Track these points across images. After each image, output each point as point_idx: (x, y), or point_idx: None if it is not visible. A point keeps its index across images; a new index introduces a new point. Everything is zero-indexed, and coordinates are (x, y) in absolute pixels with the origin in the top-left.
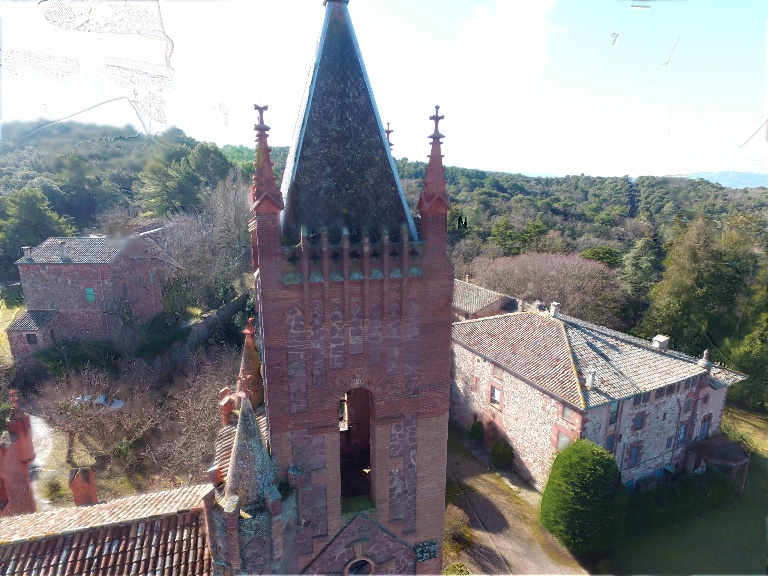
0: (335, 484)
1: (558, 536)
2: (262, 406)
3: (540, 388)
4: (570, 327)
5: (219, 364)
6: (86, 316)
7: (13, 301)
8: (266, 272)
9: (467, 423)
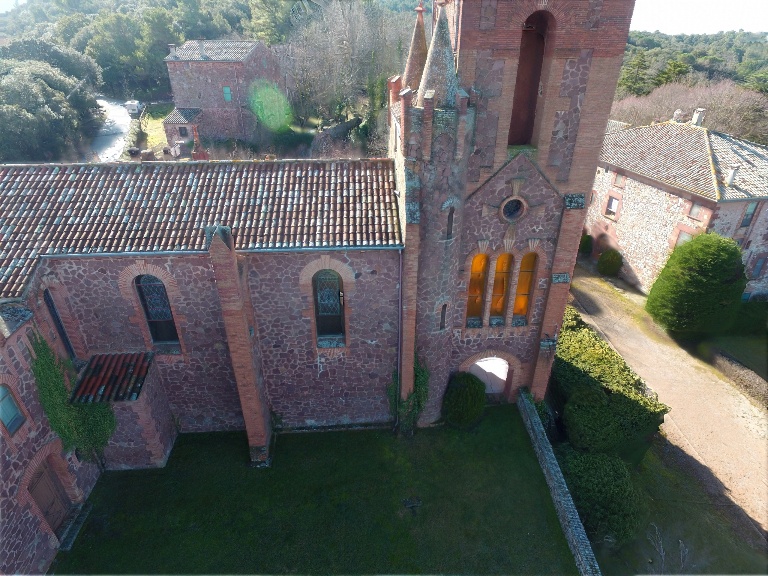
0: (507, 115)
1: (662, 319)
2: None
3: (668, 189)
4: (713, 135)
5: (346, 151)
6: (224, 115)
7: (157, 114)
8: None
9: None
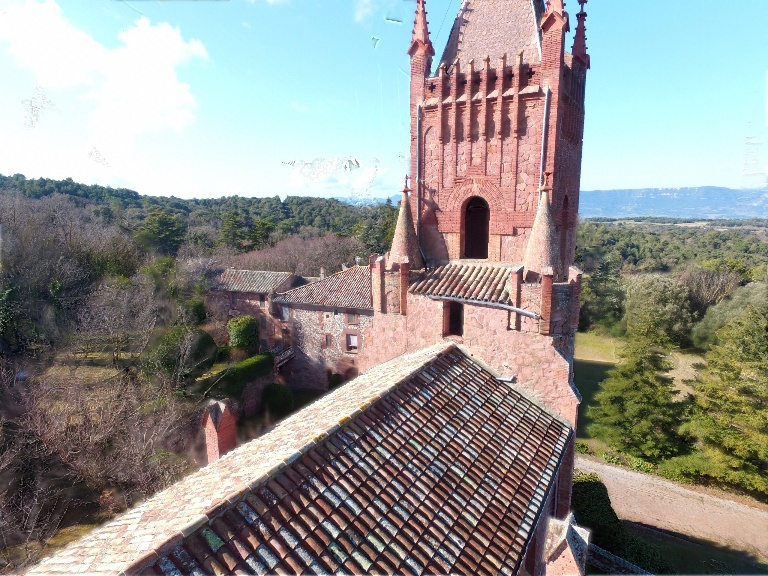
0: None
1: None
2: (428, 263)
3: None
4: None
5: (59, 370)
6: None
7: None
8: (560, 81)
9: (319, 383)
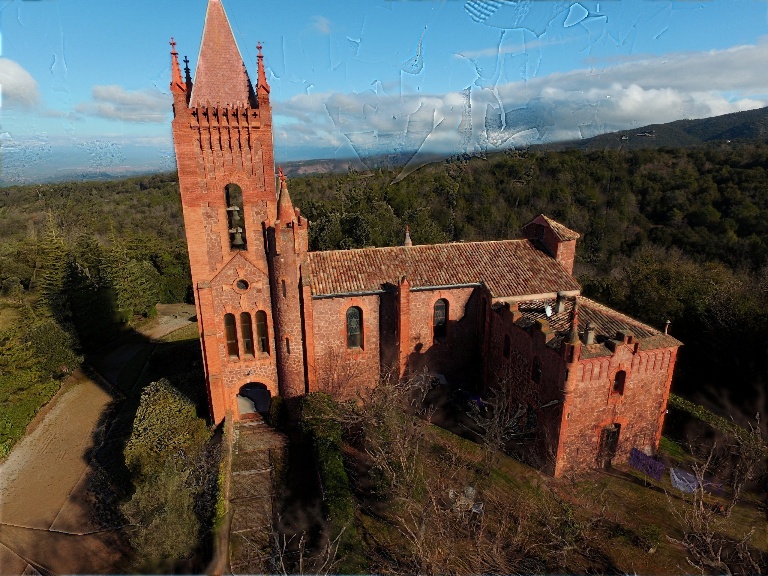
0: None
1: None
2: None
3: None
4: None
5: None
6: None
7: None
8: None
9: None
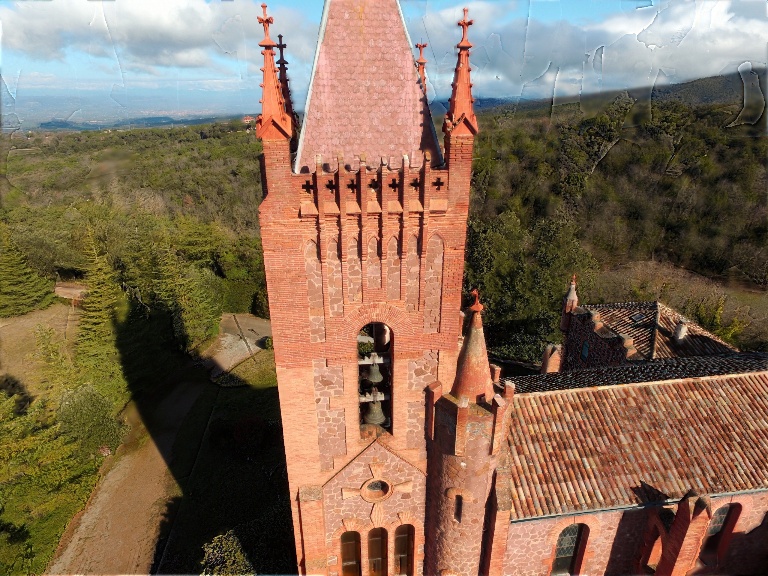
0: None
1: None
2: None
3: None
4: None
5: None
6: None
7: None
8: None
9: None
